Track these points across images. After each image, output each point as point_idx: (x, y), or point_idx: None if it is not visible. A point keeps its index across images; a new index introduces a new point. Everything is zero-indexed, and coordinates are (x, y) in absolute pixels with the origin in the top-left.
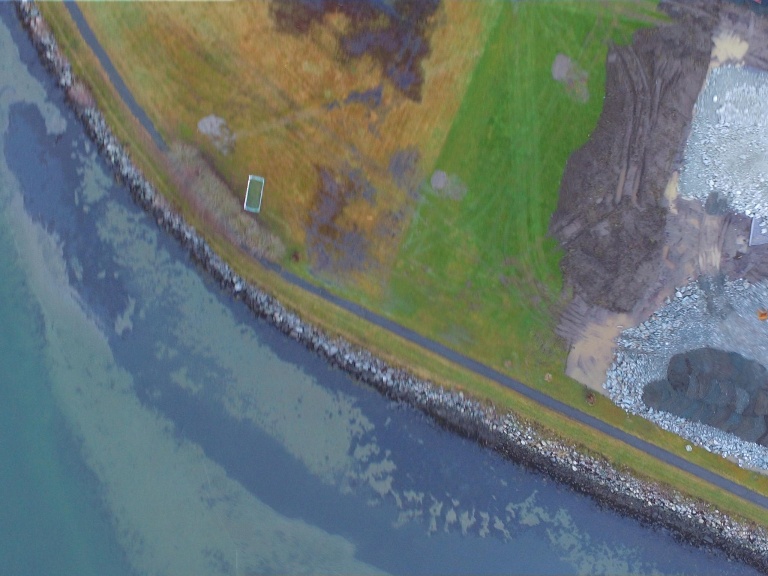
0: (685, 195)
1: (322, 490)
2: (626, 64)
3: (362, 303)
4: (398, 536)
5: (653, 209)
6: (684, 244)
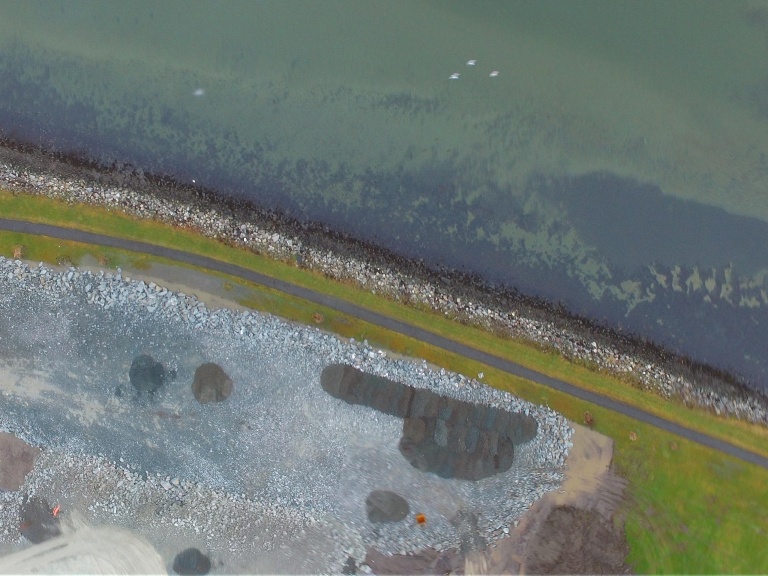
0: None
1: None
2: None
3: None
4: (765, 262)
5: None
6: None
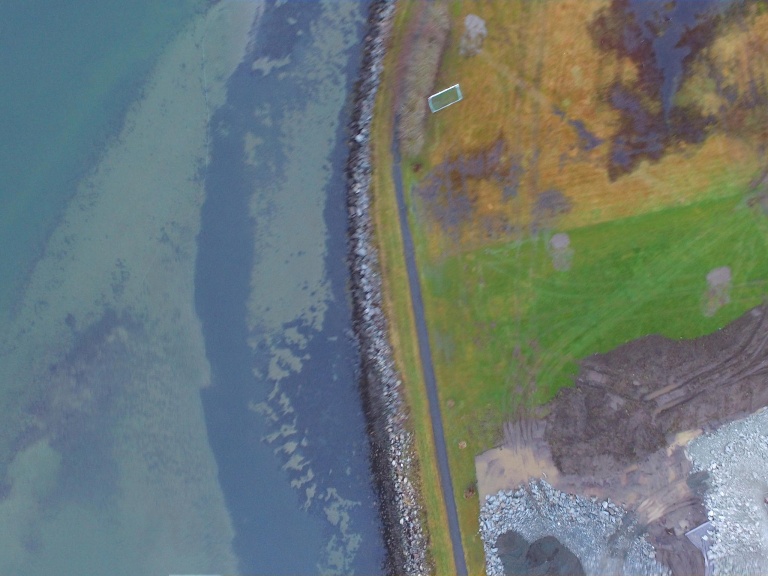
0: (689, 451)
1: (239, 323)
2: (760, 327)
3: (417, 248)
4: (243, 414)
5: (660, 432)
6: (649, 479)
